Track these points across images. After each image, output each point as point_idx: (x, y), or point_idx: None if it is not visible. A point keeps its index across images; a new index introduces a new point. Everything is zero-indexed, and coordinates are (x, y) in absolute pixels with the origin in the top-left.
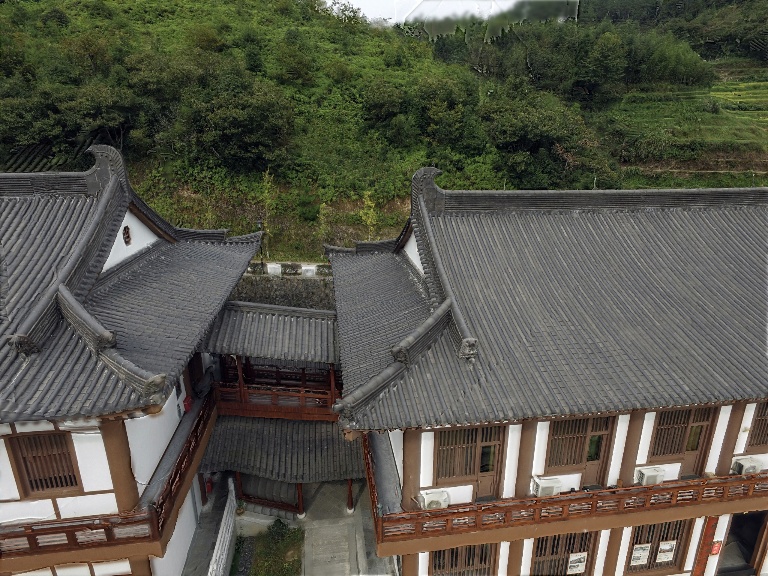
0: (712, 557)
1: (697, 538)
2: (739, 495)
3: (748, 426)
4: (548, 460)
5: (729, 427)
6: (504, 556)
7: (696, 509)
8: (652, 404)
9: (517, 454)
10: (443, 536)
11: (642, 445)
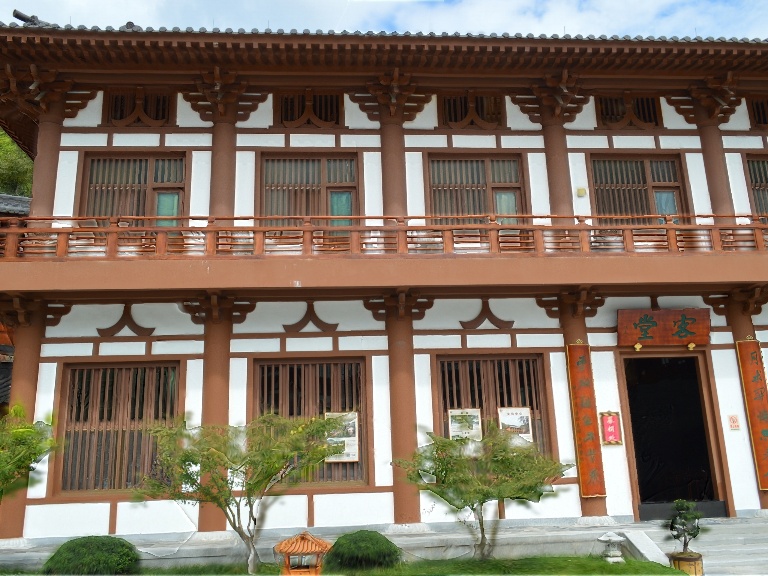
0: (612, 451)
1: (565, 401)
2: (566, 251)
3: (583, 187)
4: (258, 213)
5: (551, 186)
6: (194, 393)
7: (492, 266)
8: (332, 31)
9: (207, 199)
10: (49, 262)
11: (412, 204)
